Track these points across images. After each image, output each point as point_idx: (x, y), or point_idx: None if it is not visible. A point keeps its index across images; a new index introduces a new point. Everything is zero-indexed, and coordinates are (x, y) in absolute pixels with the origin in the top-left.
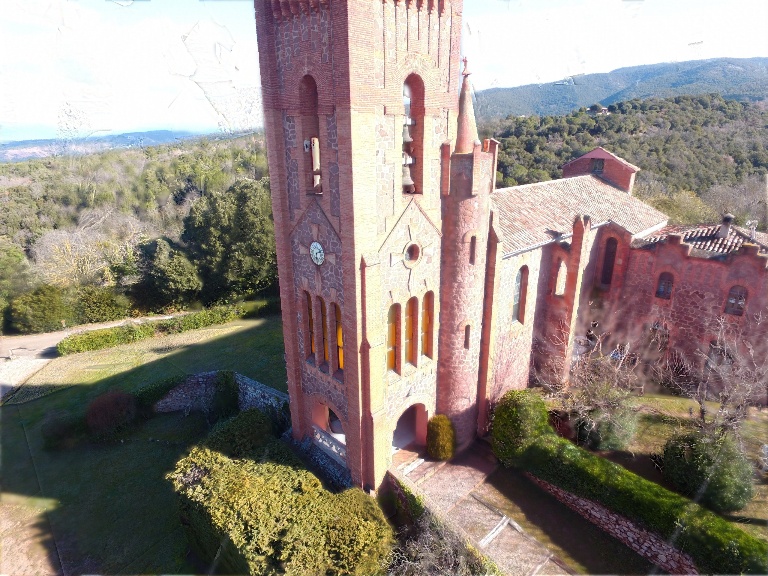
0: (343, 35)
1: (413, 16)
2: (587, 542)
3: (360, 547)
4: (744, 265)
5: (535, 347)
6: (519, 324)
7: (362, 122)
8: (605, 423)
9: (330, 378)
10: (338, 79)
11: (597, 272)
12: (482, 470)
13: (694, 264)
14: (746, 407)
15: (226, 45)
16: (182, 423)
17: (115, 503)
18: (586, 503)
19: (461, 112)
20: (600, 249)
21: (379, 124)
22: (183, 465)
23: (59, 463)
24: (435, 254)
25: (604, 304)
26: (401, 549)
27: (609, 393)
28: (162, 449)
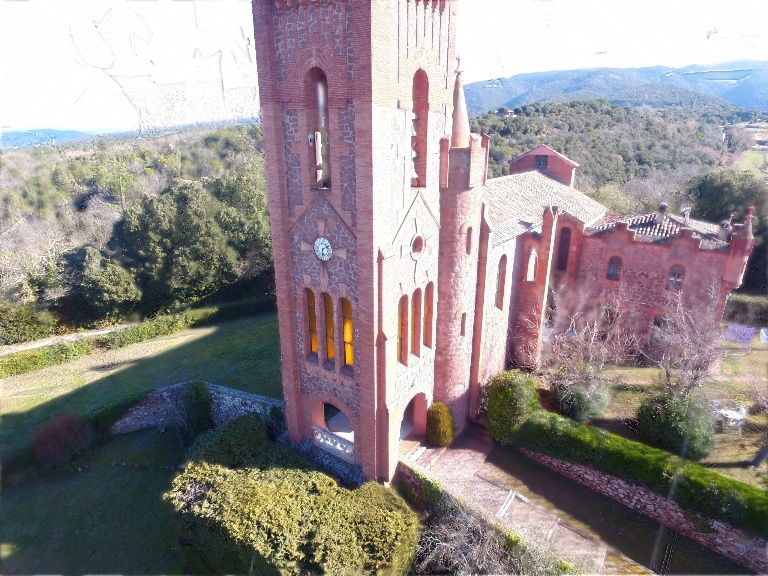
0: (365, 28)
1: (421, 13)
2: (585, 503)
3: (393, 537)
4: (681, 247)
5: (510, 332)
6: (498, 310)
7: (381, 115)
8: (585, 395)
9: (336, 375)
10: (357, 72)
11: (553, 259)
12: (481, 451)
13: (639, 248)
14: (693, 370)
15: (143, 36)
16: (148, 442)
17: (86, 537)
18: (579, 469)
19: (455, 108)
20: (556, 238)
21: (393, 118)
22: (180, 482)
23: (4, 503)
24: (434, 246)
25: (560, 289)
26: None
27: (586, 367)
28: (130, 472)
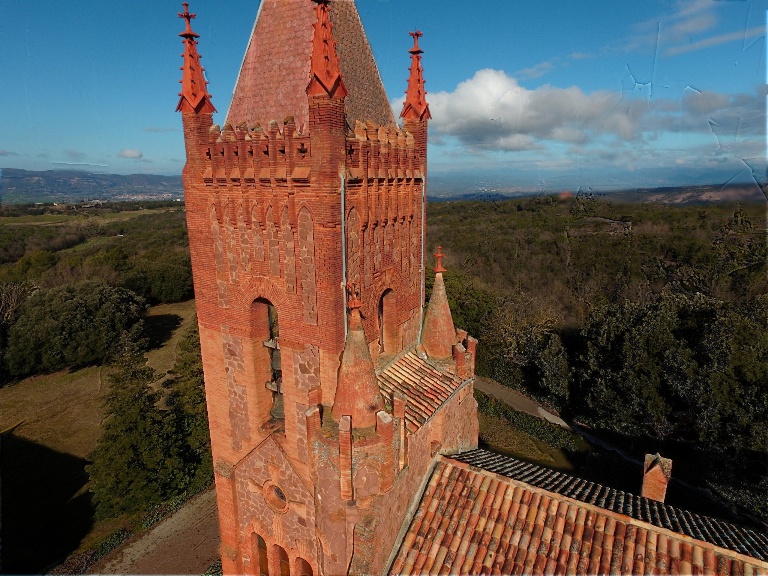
0: None
1: (257, 235)
2: None
3: None
4: None
5: None
6: None
7: (209, 337)
8: None
9: None
10: None
11: None
12: None
13: None
14: None
15: None
16: None
17: None
18: None
19: None
20: None
21: (227, 342)
22: None
23: None
24: (312, 520)
25: None
26: None
27: None
28: None
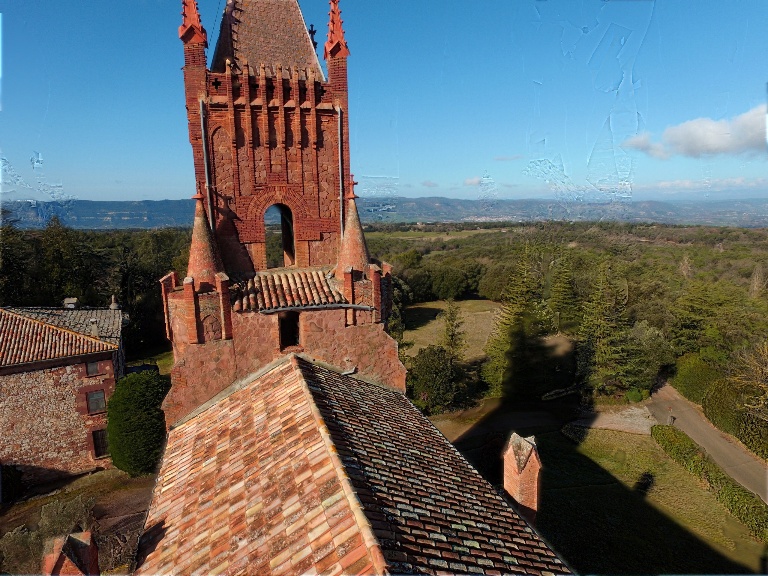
0: None
1: None
2: None
3: None
4: None
5: None
6: None
7: None
8: None
9: None
10: None
11: None
12: None
13: None
14: None
15: None
16: None
17: None
18: None
19: None
20: None
21: None
22: None
23: None
24: None
25: None
26: None
27: None
28: None
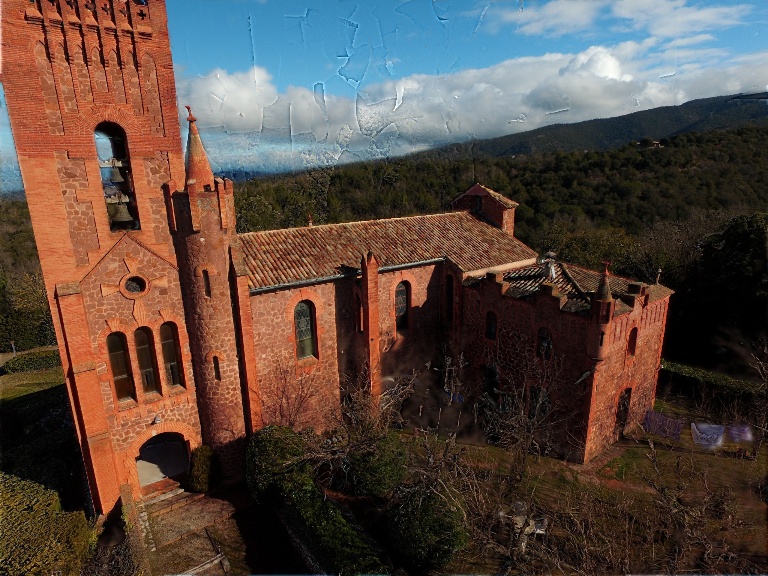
0: None
1: (98, 72)
2: None
3: (28, 567)
4: (546, 306)
5: (347, 384)
6: (314, 359)
7: (36, 165)
8: (359, 465)
9: None
10: None
11: (442, 310)
12: (235, 505)
13: (509, 304)
14: (524, 459)
15: (219, 95)
16: None
17: None
18: (304, 548)
19: (188, 154)
20: (442, 286)
21: (63, 167)
22: None
23: None
24: (172, 286)
25: (450, 343)
26: (90, 575)
27: (369, 434)
28: None
